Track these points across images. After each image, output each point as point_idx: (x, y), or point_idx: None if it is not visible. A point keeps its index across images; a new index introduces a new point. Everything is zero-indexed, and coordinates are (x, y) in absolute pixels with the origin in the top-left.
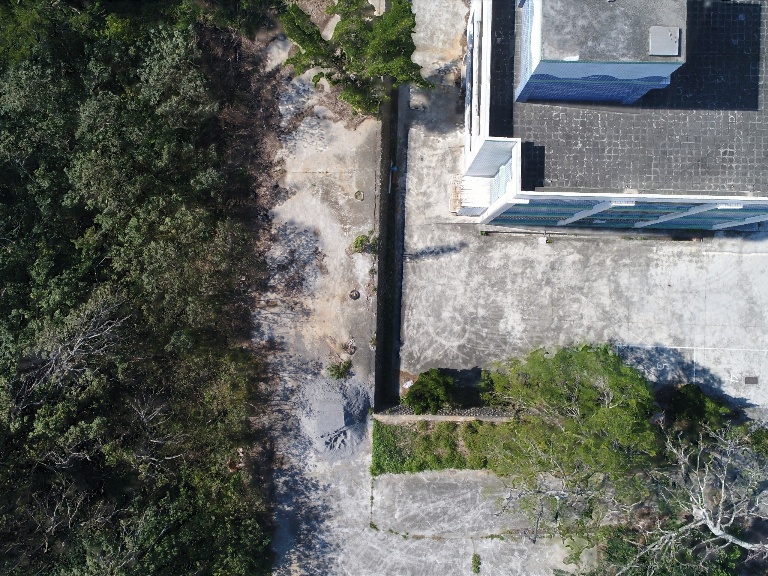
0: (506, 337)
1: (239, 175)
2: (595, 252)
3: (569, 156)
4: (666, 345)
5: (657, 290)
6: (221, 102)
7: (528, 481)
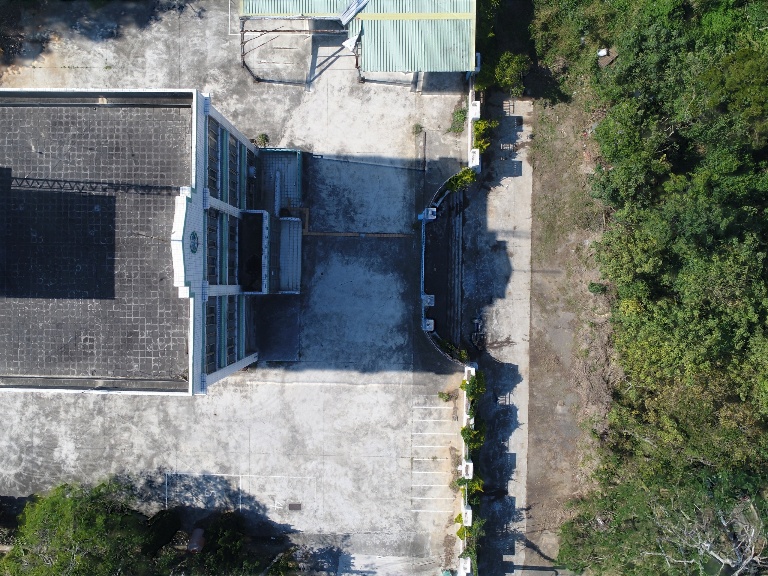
0: (60, 465)
1: None
2: None
3: None
4: (213, 473)
5: (204, 419)
6: None
7: None
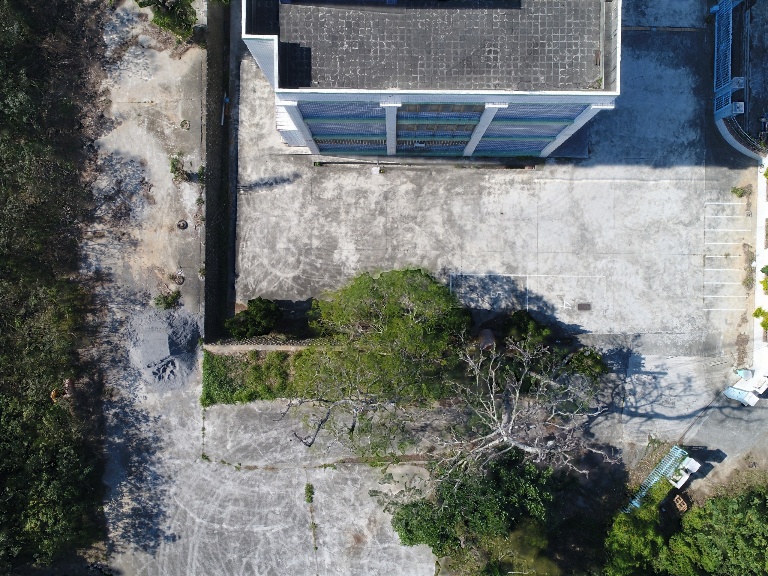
0: (340, 267)
1: (62, 105)
2: (428, 181)
3: (335, 57)
4: (499, 273)
5: (490, 218)
6: (44, 32)
7: (308, 387)
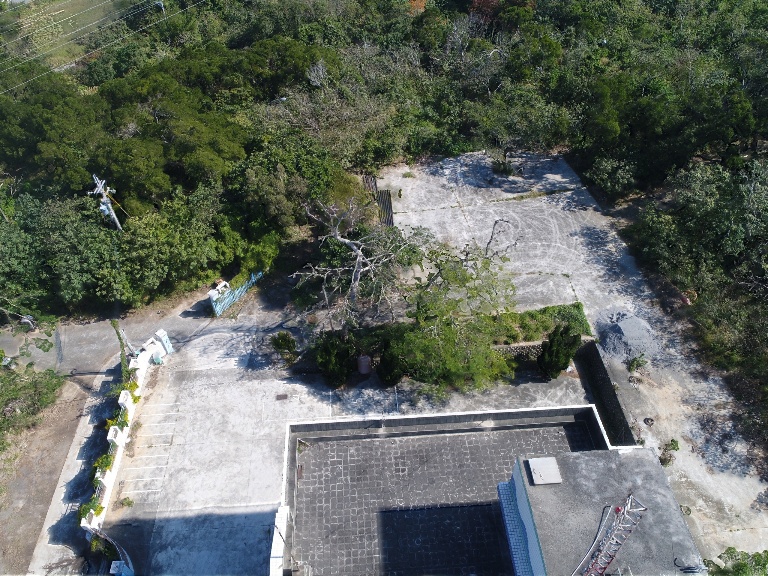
0: None
1: None
2: None
3: None
4: None
5: None
6: None
7: None
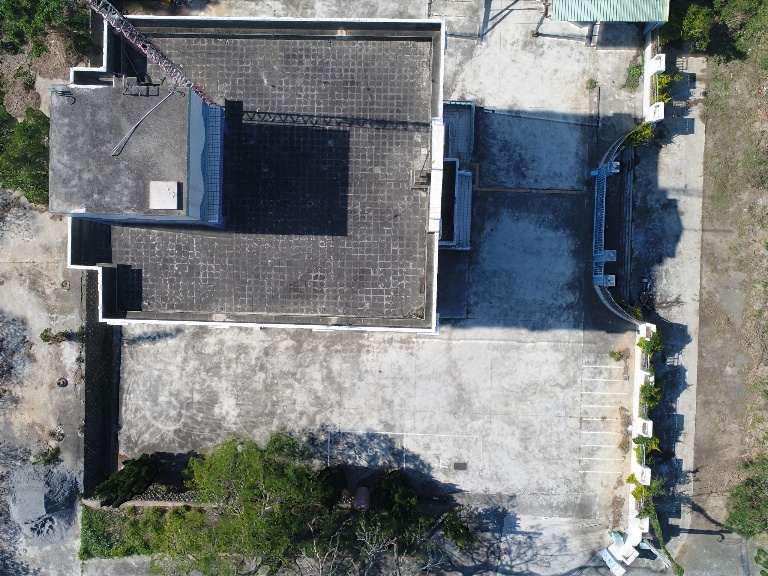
0: (221, 422)
1: None
2: (308, 338)
3: (166, 279)
4: (377, 431)
5: (368, 376)
6: None
7: None
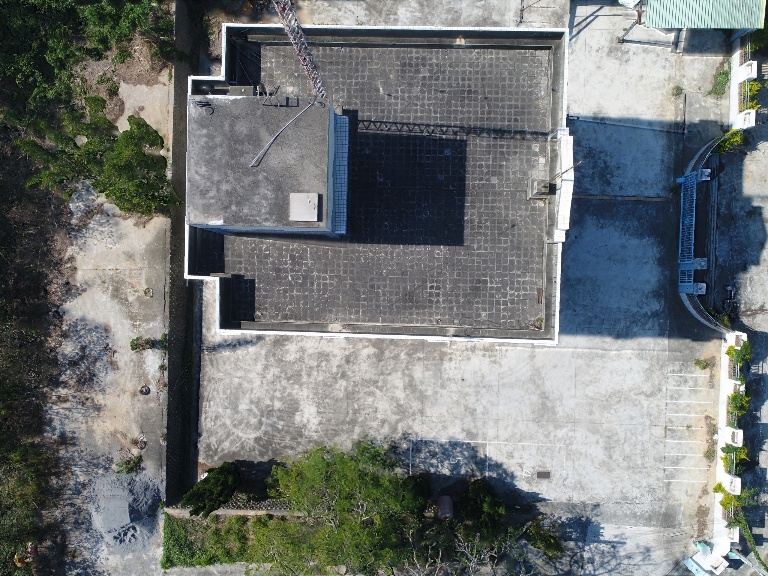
0: (302, 430)
1: (28, 273)
2: (390, 346)
3: (279, 289)
4: (459, 439)
5: (451, 384)
6: (11, 200)
7: None
